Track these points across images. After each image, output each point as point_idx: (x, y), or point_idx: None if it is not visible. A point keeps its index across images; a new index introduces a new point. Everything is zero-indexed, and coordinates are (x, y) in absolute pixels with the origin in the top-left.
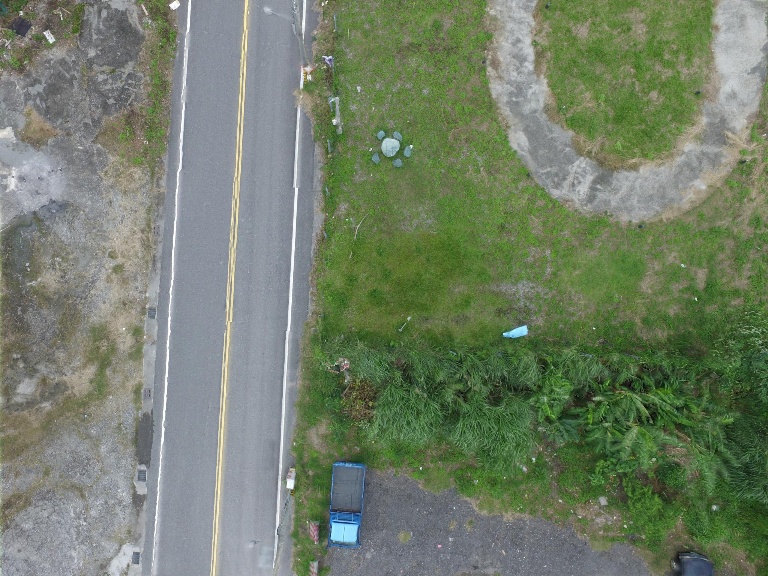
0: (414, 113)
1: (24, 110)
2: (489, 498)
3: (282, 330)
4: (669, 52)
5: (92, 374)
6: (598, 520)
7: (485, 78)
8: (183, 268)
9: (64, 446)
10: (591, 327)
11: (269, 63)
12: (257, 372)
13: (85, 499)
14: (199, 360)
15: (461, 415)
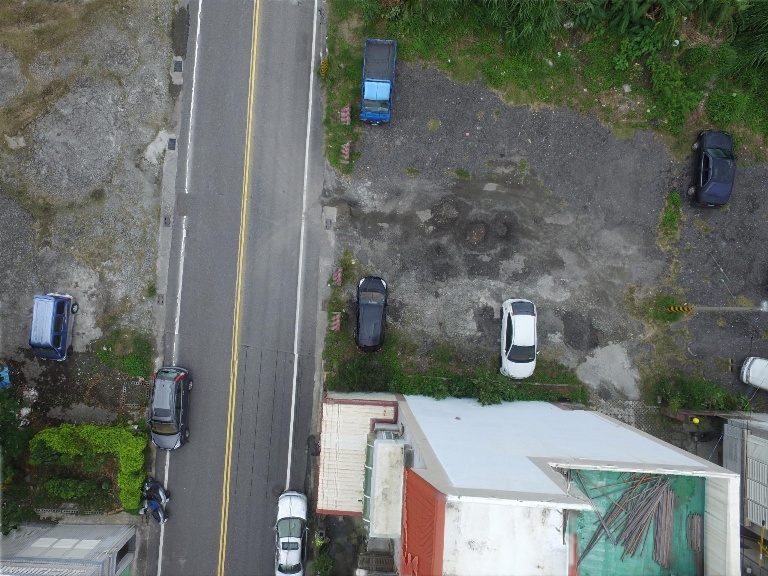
0: None
1: None
2: (516, 89)
3: None
4: None
5: None
6: (622, 107)
7: None
8: None
9: (102, 36)
10: None
11: None
12: None
13: (123, 87)
14: None
15: None
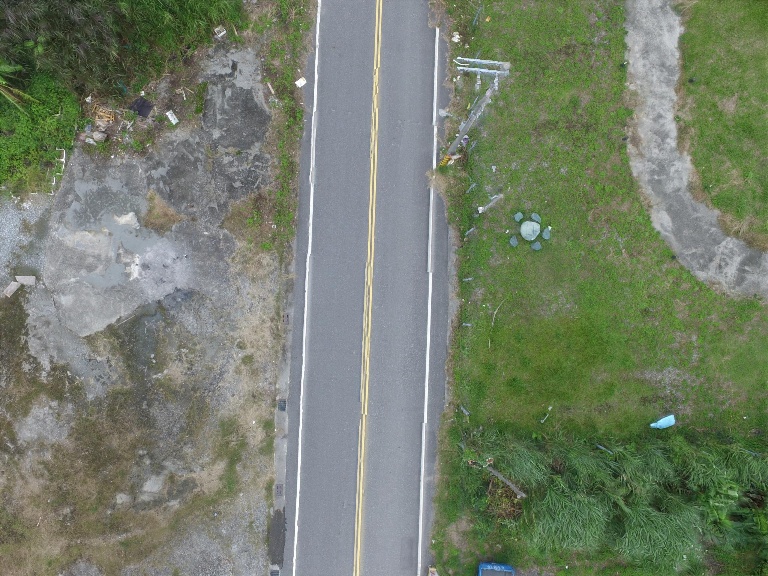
0: (552, 193)
1: (147, 195)
2: None
3: (418, 422)
4: None
5: (221, 470)
6: None
7: (626, 156)
8: (314, 358)
9: (194, 546)
10: (741, 416)
11: (400, 142)
12: (393, 467)
13: None
14: (333, 455)
15: (627, 523)
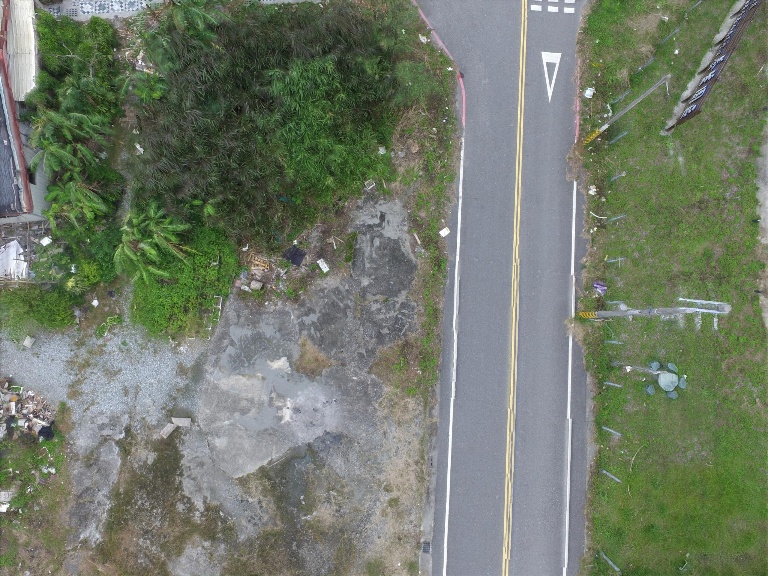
0: (687, 342)
1: (299, 340)
2: None
3: (559, 566)
4: None
5: None
6: None
7: (758, 307)
8: (458, 501)
9: None
10: None
11: (540, 291)
12: None
13: None
14: None
15: None
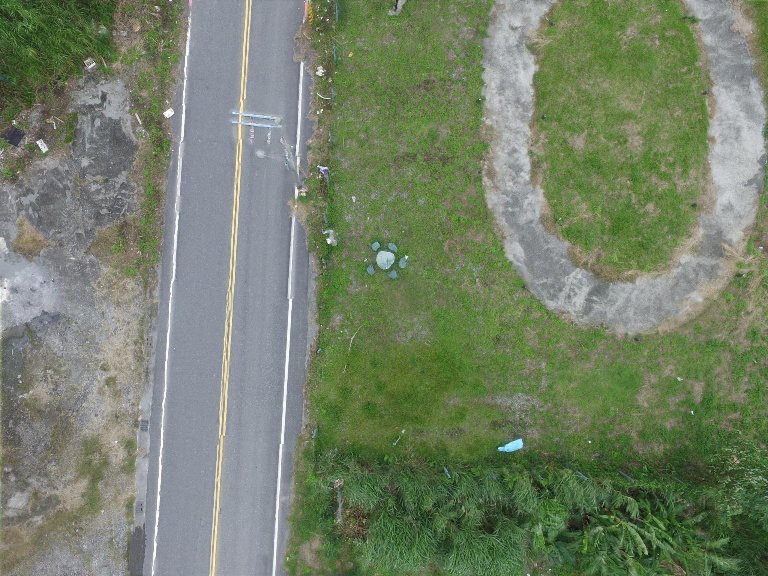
0: (409, 223)
1: (16, 221)
2: None
3: (276, 443)
4: (666, 164)
5: (84, 488)
6: None
7: (481, 188)
8: (176, 380)
9: (55, 561)
10: (587, 441)
11: (263, 172)
12: (250, 486)
13: None
14: (192, 474)
15: (455, 545)
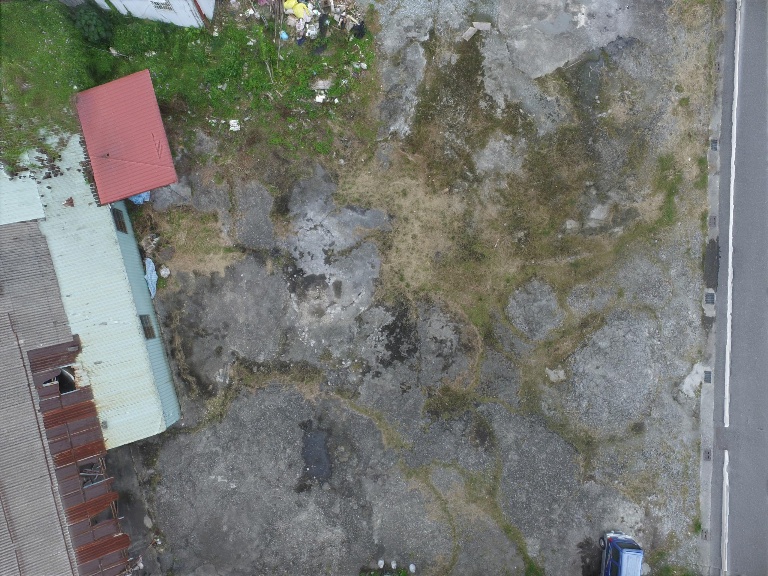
0: None
1: None
2: None
3: None
4: None
5: (661, 201)
6: None
7: None
8: (744, 102)
9: (637, 269)
10: None
11: None
12: None
13: (658, 320)
14: (763, 189)
15: None
